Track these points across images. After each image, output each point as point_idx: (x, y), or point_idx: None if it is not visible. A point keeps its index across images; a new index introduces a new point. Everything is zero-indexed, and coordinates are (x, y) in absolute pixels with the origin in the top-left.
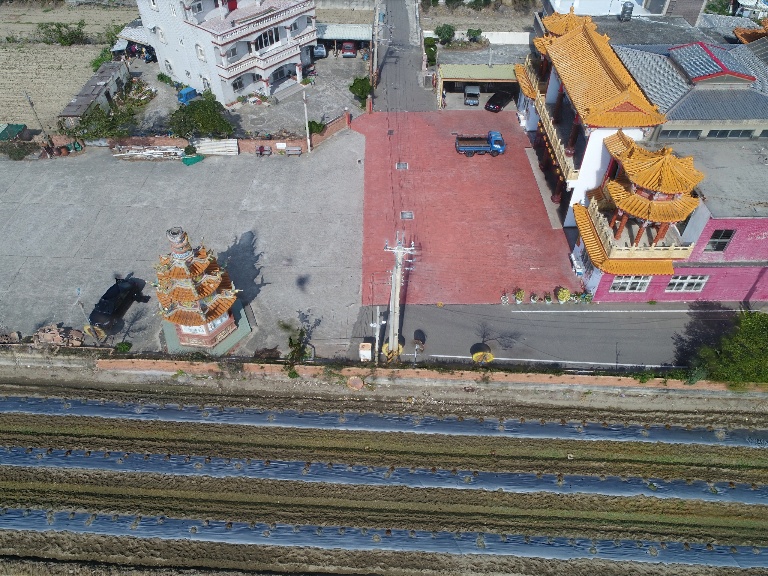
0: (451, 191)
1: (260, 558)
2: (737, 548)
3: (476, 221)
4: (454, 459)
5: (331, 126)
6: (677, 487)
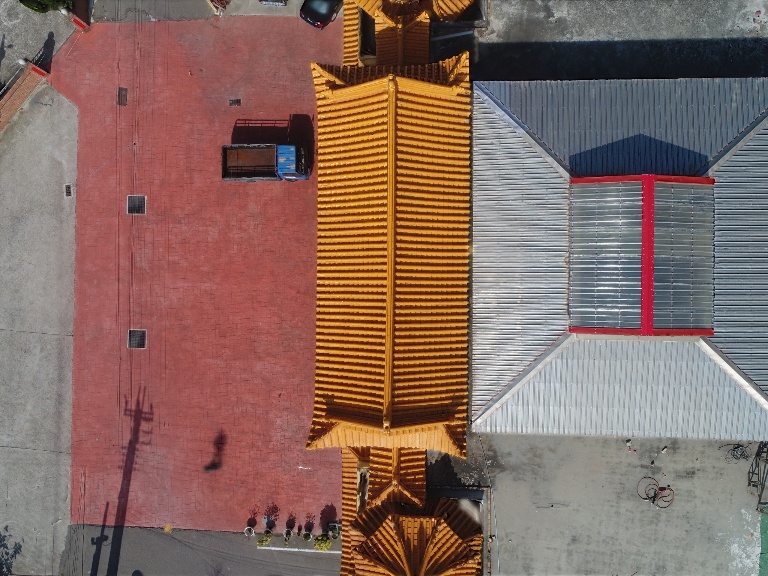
0: (209, 281)
1: None
2: None
3: (237, 359)
4: None
5: (7, 102)
6: None
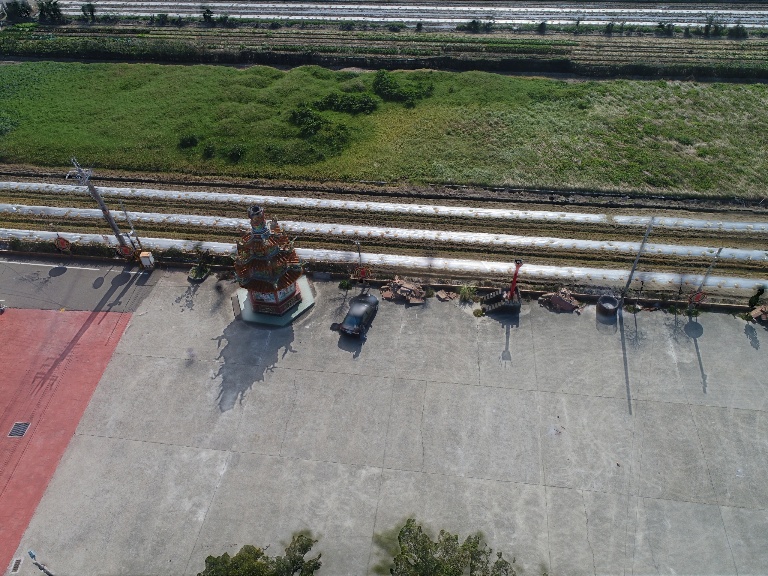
0: None
1: (251, 191)
2: (4, 187)
3: None
4: (123, 224)
5: None
6: (5, 207)
